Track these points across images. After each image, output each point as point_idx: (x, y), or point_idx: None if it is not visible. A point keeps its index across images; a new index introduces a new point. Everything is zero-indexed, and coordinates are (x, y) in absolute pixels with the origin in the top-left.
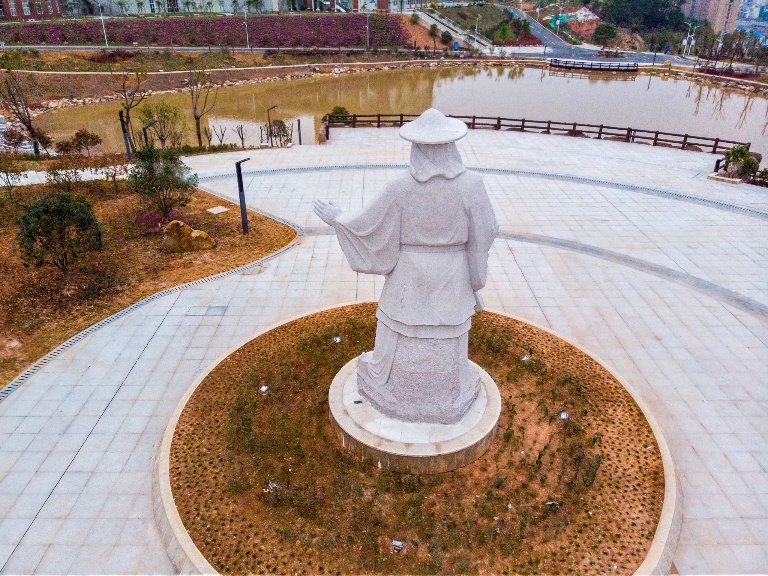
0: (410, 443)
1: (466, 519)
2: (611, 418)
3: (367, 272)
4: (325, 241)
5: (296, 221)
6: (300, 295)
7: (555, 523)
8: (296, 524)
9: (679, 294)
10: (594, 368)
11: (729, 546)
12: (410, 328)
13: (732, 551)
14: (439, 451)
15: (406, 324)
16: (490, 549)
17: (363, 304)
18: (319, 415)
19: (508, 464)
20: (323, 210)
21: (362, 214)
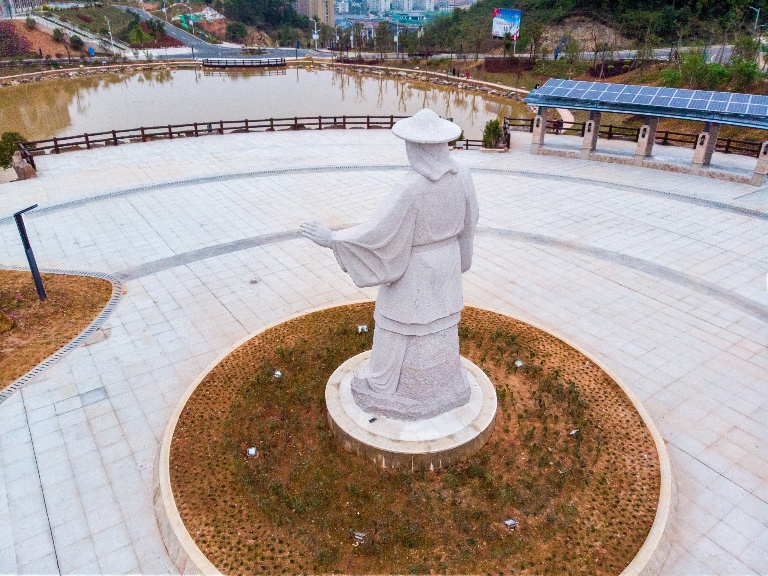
0: (451, 434)
1: (533, 475)
2: (547, 352)
3: (377, 284)
4: (153, 282)
5: (95, 269)
6: (181, 345)
7: (587, 446)
8: (413, 557)
9: (496, 244)
10: (502, 319)
11: (675, 409)
12: (424, 327)
13: (679, 412)
14: (479, 430)
15: (423, 324)
16: (568, 489)
17: (266, 331)
18: (334, 451)
19: (520, 418)
20: (315, 232)
21: (377, 225)
